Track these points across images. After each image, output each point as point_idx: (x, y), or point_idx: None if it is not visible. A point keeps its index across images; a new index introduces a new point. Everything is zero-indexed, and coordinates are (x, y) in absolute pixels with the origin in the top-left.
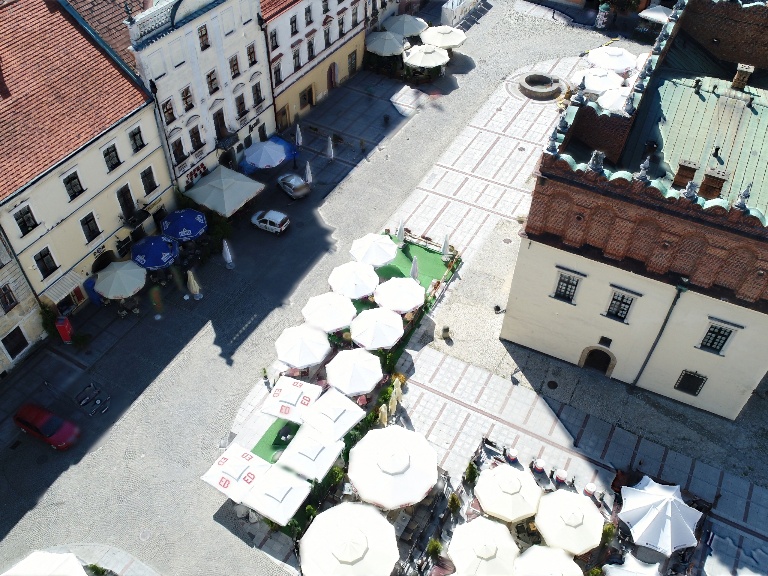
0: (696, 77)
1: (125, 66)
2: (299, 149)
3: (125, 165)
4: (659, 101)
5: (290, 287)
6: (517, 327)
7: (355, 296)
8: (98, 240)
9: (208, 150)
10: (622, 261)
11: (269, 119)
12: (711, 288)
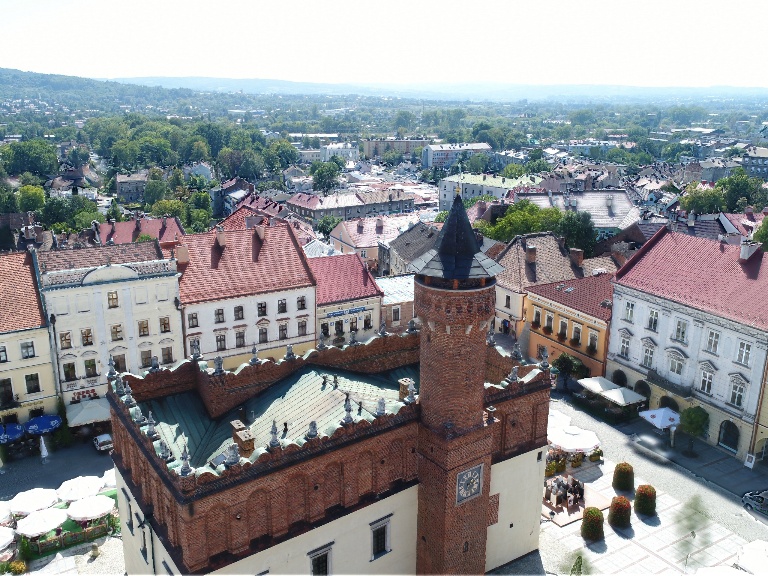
0: None
1: (44, 303)
2: None
3: (12, 364)
4: (293, 384)
5: (58, 487)
6: (127, 559)
7: (64, 497)
8: None
9: (103, 382)
10: (137, 487)
11: None
12: (161, 526)
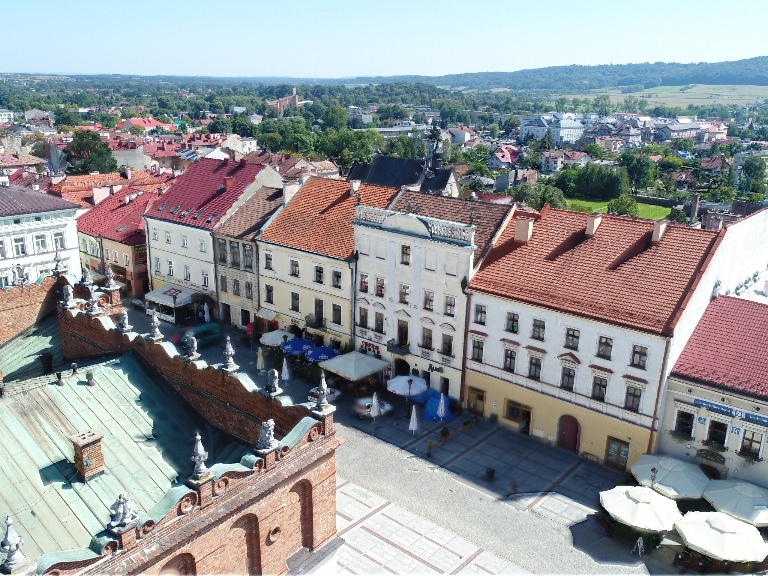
0: (174, 467)
1: None
2: (440, 420)
3: None
4: None
5: None
6: None
7: None
8: (297, 315)
9: None
10: None
11: (456, 382)
12: None
